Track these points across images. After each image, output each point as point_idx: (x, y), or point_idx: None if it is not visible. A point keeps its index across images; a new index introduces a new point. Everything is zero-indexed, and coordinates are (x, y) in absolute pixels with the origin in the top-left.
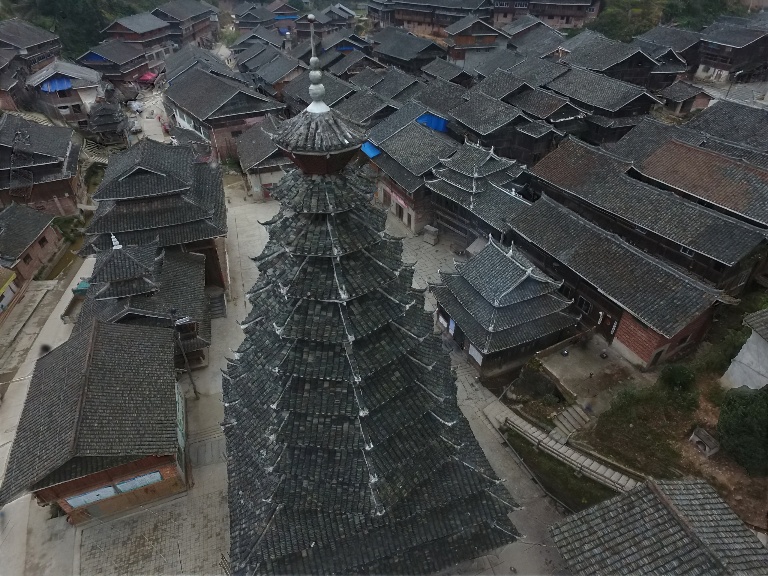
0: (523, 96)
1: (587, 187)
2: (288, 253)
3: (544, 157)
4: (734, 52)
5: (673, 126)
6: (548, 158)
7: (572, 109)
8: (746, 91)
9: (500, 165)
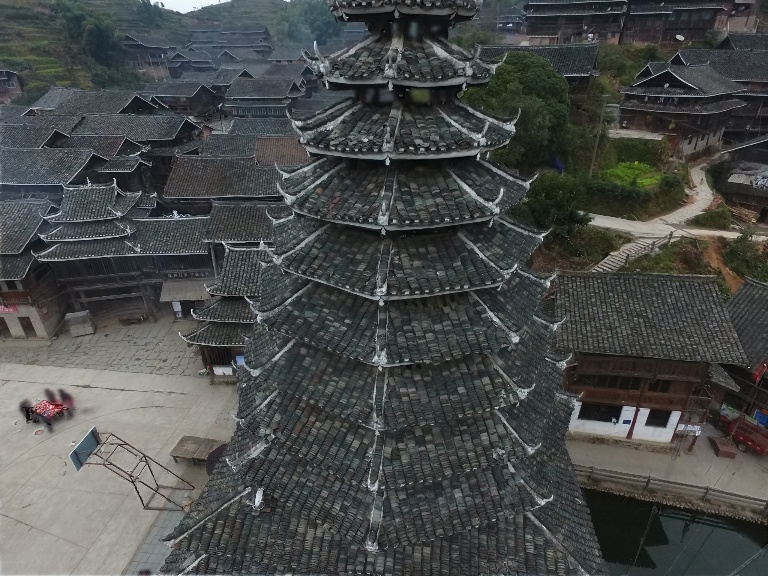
0: (61, 146)
1: (238, 186)
2: (409, 117)
3: (168, 179)
4: (189, 100)
5: (237, 134)
6: (173, 179)
7: (131, 145)
8: (227, 122)
9: (130, 200)
